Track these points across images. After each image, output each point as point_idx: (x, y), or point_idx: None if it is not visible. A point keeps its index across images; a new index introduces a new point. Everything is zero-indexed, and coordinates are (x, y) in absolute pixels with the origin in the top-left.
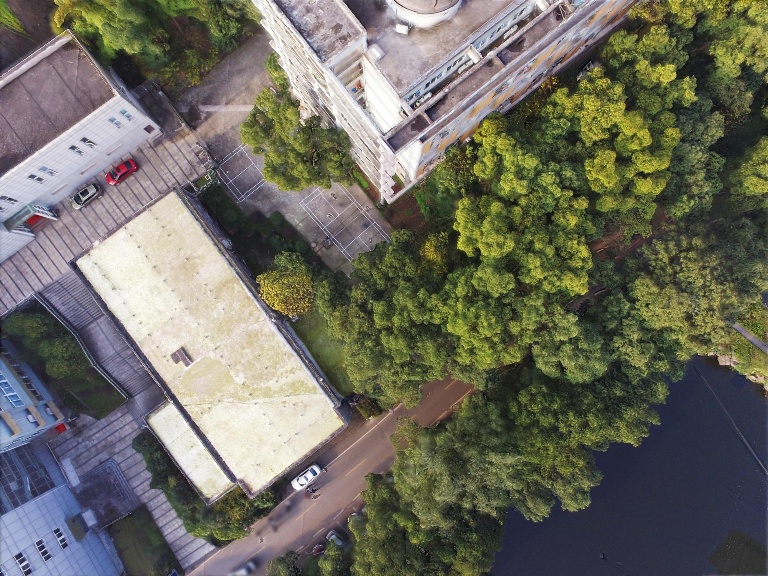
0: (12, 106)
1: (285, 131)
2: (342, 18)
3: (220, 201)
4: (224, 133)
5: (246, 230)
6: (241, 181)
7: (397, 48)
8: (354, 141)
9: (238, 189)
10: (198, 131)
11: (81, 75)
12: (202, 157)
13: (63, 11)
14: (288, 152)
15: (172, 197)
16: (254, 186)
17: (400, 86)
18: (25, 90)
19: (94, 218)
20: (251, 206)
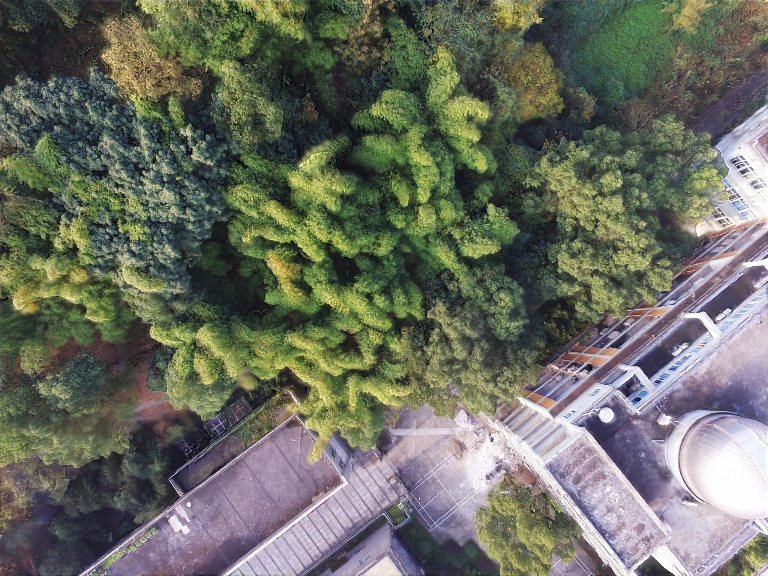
0: (235, 487)
1: (530, 541)
2: (644, 518)
3: (415, 533)
4: (415, 458)
5: (440, 561)
6: (433, 508)
7: (683, 520)
8: (601, 552)
9: (430, 516)
10: (389, 456)
11: (304, 453)
12: (393, 483)
13: (322, 448)
14: (531, 561)
15: (385, 562)
16: (446, 513)
17: (688, 560)
18: (248, 470)
19: (285, 548)
20: (444, 534)
